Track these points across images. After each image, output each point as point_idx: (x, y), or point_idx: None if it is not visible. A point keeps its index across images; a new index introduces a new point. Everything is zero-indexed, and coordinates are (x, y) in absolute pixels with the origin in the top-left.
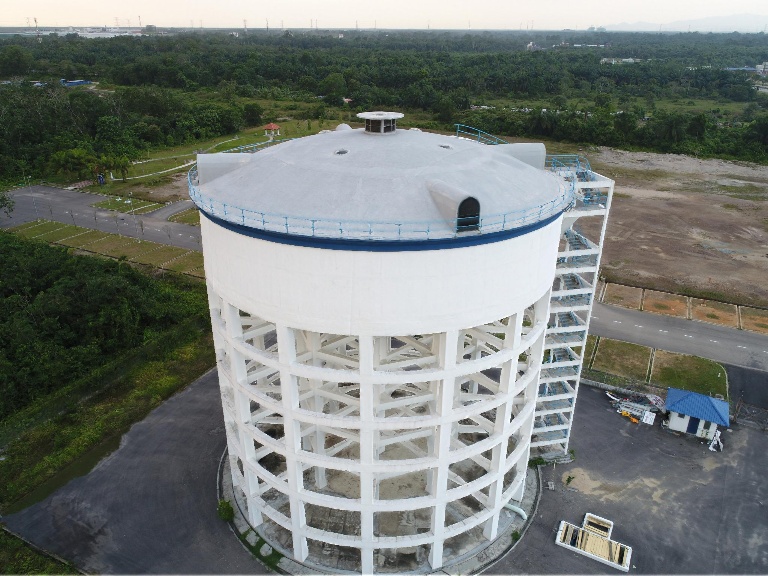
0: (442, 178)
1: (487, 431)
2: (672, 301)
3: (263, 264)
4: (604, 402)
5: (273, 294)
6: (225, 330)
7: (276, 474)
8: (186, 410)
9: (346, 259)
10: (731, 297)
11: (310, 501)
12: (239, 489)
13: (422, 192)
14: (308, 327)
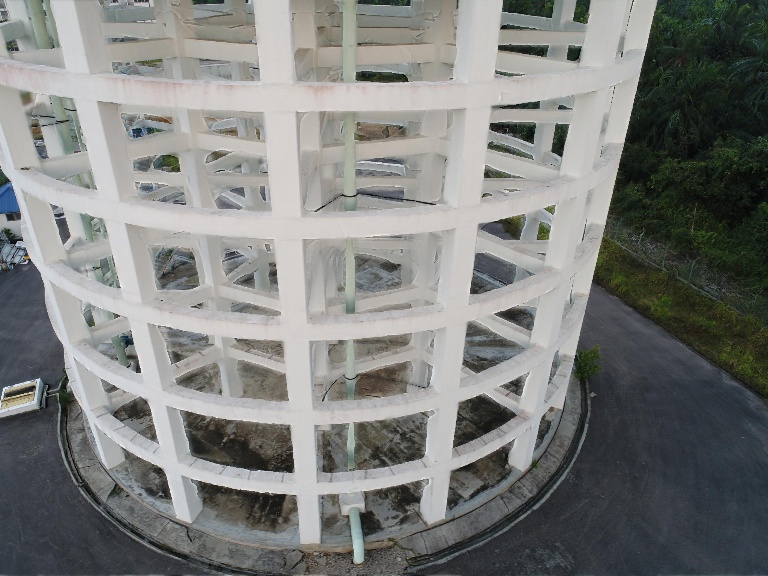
0: None
1: None
2: None
3: None
4: (6, 275)
5: None
6: None
7: None
8: None
9: None
10: None
11: None
12: None
13: None
14: None
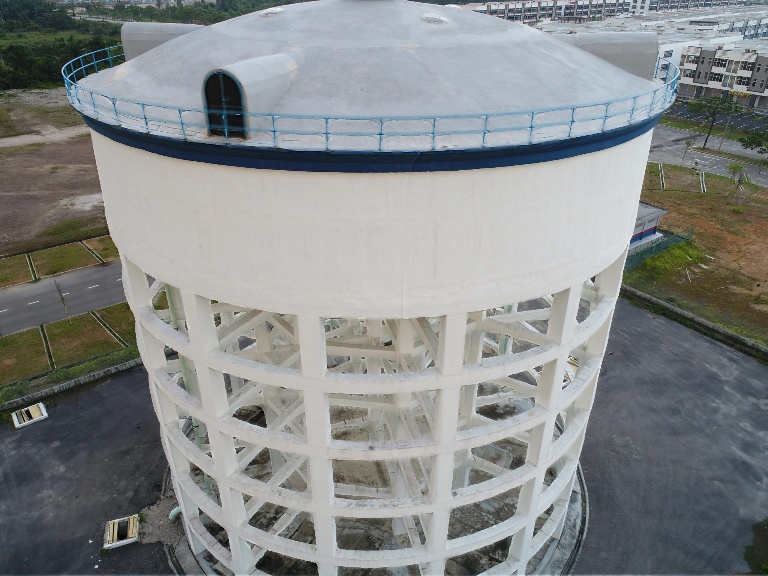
0: None
1: (547, 319)
2: None
3: (569, 199)
4: None
5: (576, 241)
6: (425, 375)
7: (346, 575)
8: None
9: (644, 142)
10: None
11: (548, 506)
12: None
13: (577, 49)
14: (604, 265)
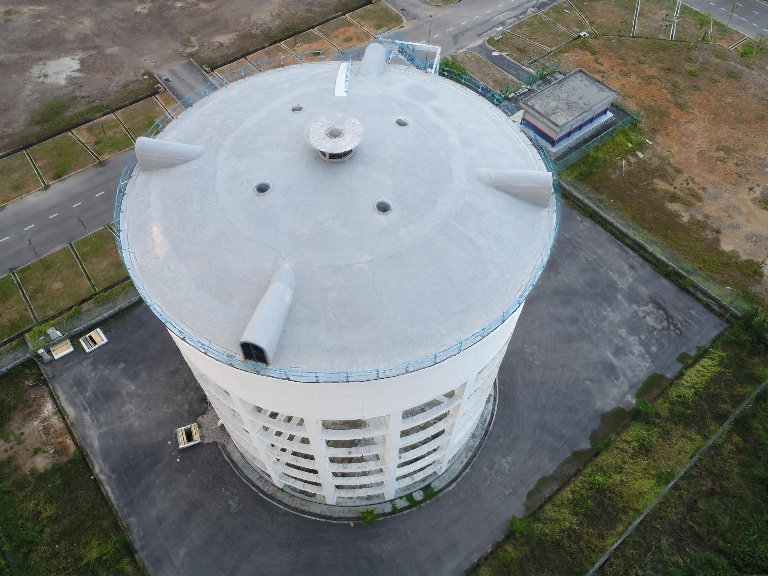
0: (475, 165)
1: None
2: (278, 57)
3: None
4: None
5: None
6: (380, 430)
7: (338, 462)
8: (174, 531)
9: None
10: (301, 23)
11: None
12: (341, 500)
13: (492, 193)
14: None
